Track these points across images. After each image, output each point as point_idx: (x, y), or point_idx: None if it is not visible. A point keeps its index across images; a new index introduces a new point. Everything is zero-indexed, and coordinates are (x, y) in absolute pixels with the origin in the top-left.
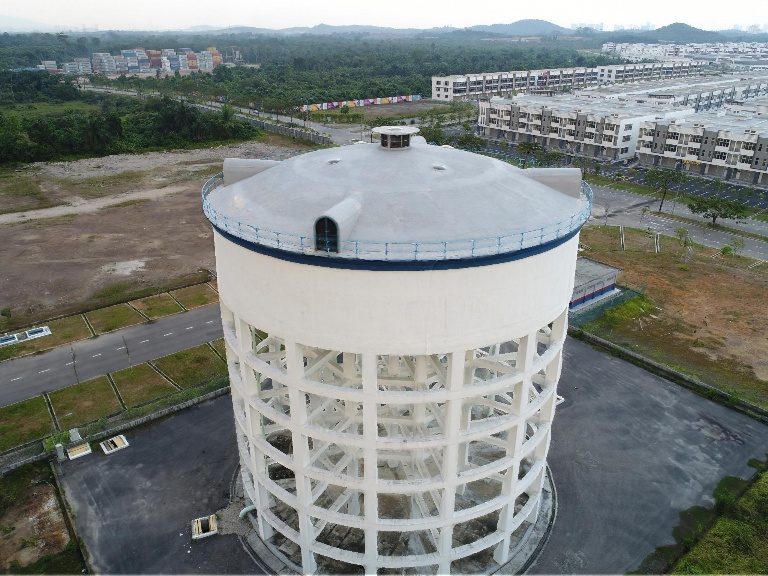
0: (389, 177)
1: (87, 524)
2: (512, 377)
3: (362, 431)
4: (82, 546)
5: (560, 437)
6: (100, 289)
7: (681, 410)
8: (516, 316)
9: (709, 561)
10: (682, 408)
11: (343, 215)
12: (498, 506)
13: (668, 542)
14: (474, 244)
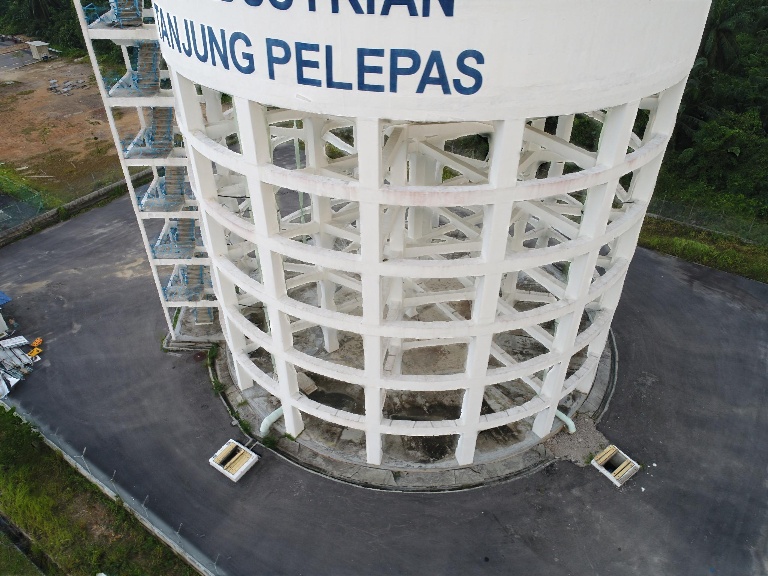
0: None
1: None
2: None
3: (358, 354)
4: None
5: None
6: None
7: None
8: None
9: None
10: None
11: None
12: None
13: None
14: None
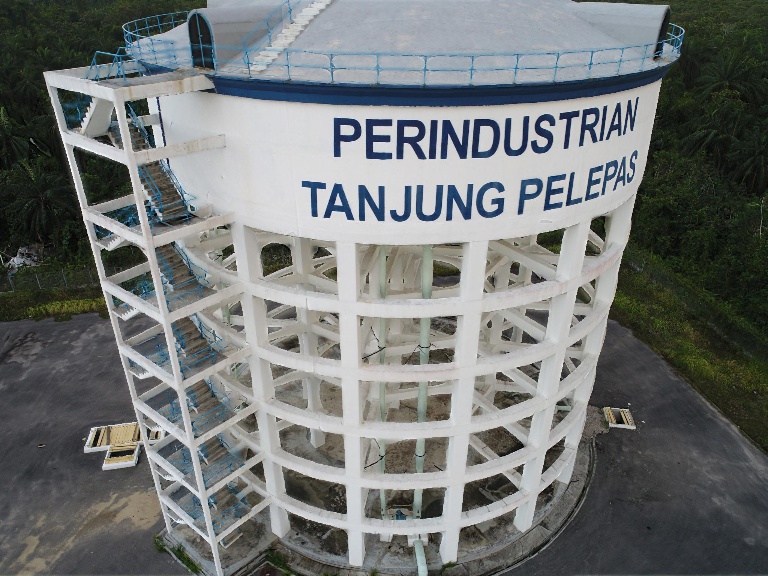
0: None
1: None
2: None
3: (404, 463)
4: None
5: None
6: None
7: (1, 376)
8: None
9: None
10: None
11: None
12: None
13: None
14: None
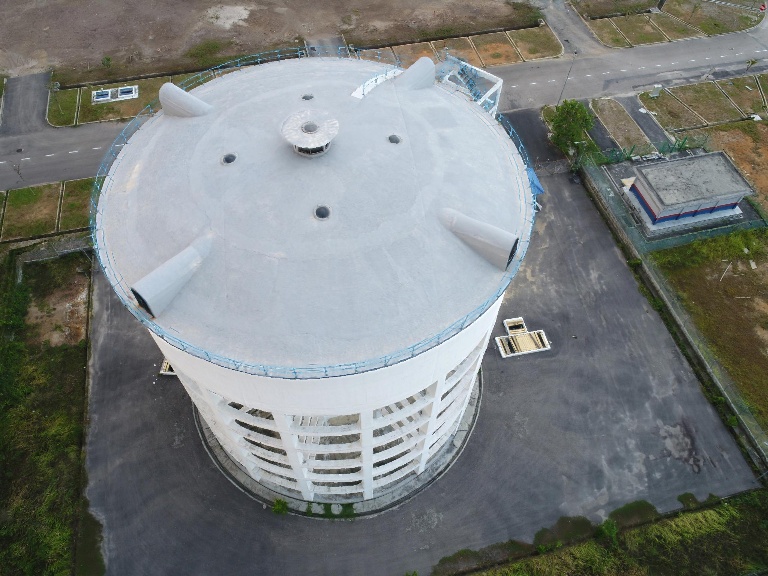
0: (256, 218)
1: (98, 328)
2: (345, 431)
3: None
4: (88, 347)
5: (512, 391)
6: (196, 44)
7: (667, 407)
8: (339, 404)
9: (544, 574)
10: (670, 404)
11: (161, 285)
12: (350, 480)
13: (526, 539)
14: (282, 353)
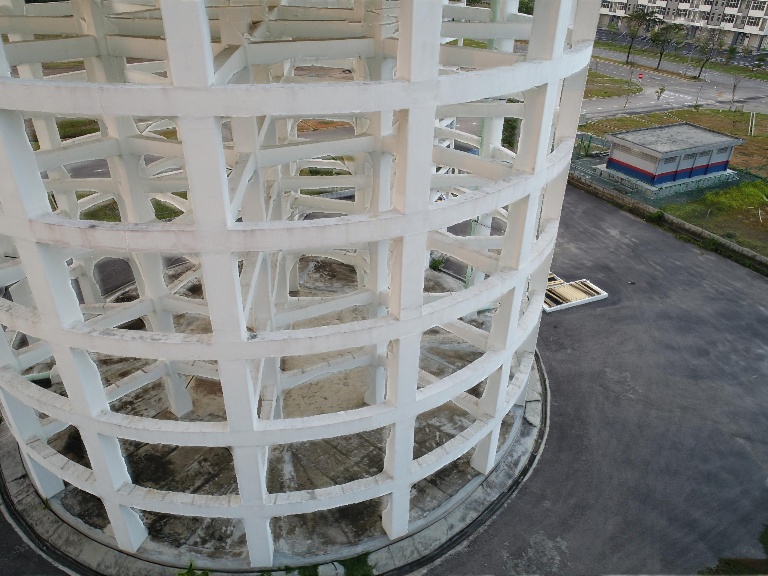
0: None
1: None
2: (369, 85)
3: None
4: None
5: (583, 345)
6: None
7: None
8: None
9: None
10: None
11: None
12: (367, 423)
13: (748, 552)
14: None
